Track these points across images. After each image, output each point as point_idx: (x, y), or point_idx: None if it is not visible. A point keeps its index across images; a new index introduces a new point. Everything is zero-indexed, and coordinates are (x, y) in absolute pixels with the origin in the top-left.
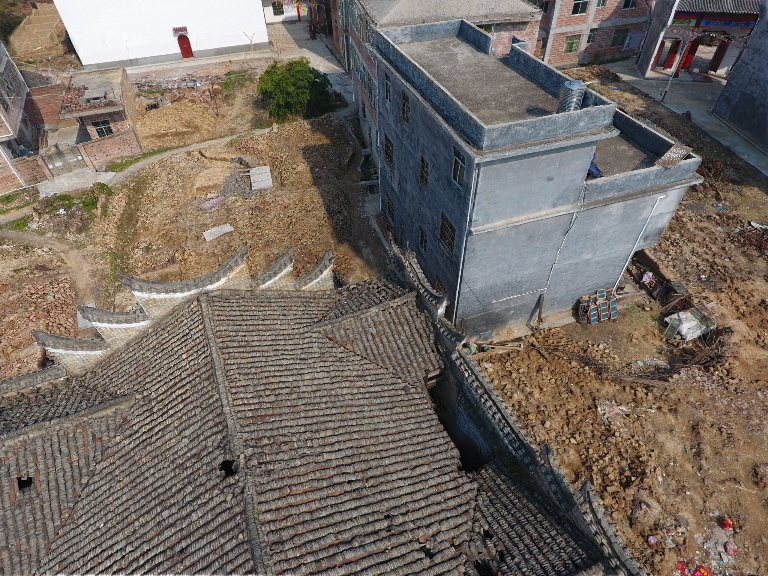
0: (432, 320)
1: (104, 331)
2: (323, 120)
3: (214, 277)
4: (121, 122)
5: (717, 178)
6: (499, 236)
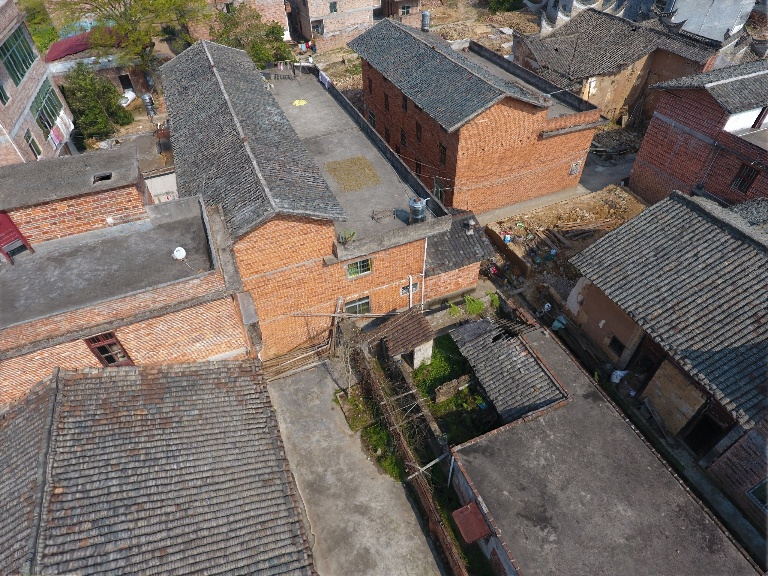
0: (666, 26)
1: (558, 18)
2: (525, 10)
3: (594, 1)
4: (416, 8)
5: (767, 23)
6: (687, 1)
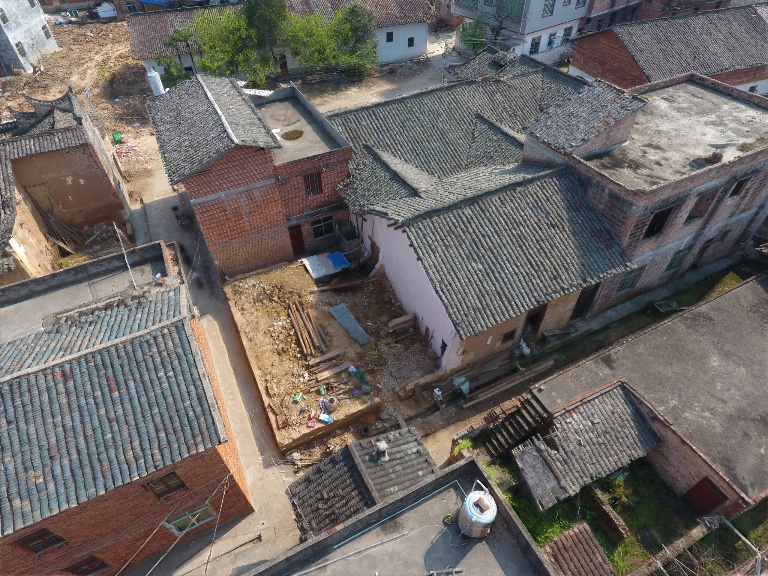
0: None
1: None
2: None
3: None
4: None
5: None
6: None
